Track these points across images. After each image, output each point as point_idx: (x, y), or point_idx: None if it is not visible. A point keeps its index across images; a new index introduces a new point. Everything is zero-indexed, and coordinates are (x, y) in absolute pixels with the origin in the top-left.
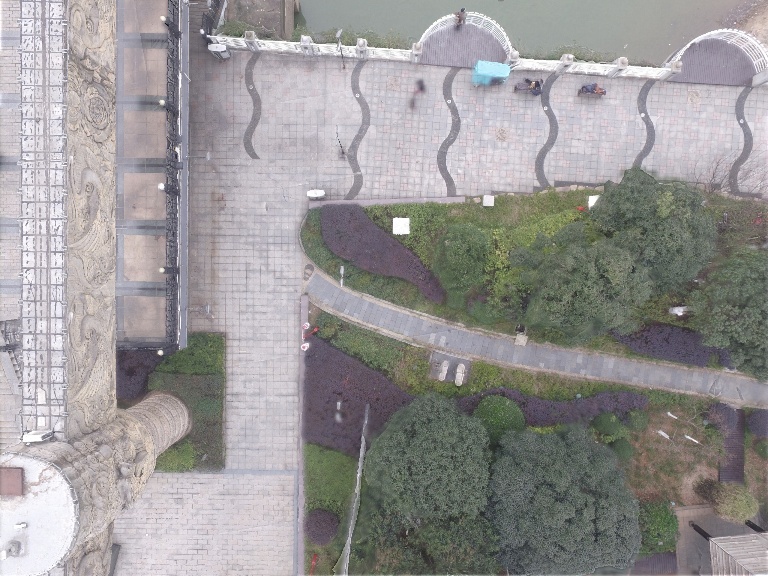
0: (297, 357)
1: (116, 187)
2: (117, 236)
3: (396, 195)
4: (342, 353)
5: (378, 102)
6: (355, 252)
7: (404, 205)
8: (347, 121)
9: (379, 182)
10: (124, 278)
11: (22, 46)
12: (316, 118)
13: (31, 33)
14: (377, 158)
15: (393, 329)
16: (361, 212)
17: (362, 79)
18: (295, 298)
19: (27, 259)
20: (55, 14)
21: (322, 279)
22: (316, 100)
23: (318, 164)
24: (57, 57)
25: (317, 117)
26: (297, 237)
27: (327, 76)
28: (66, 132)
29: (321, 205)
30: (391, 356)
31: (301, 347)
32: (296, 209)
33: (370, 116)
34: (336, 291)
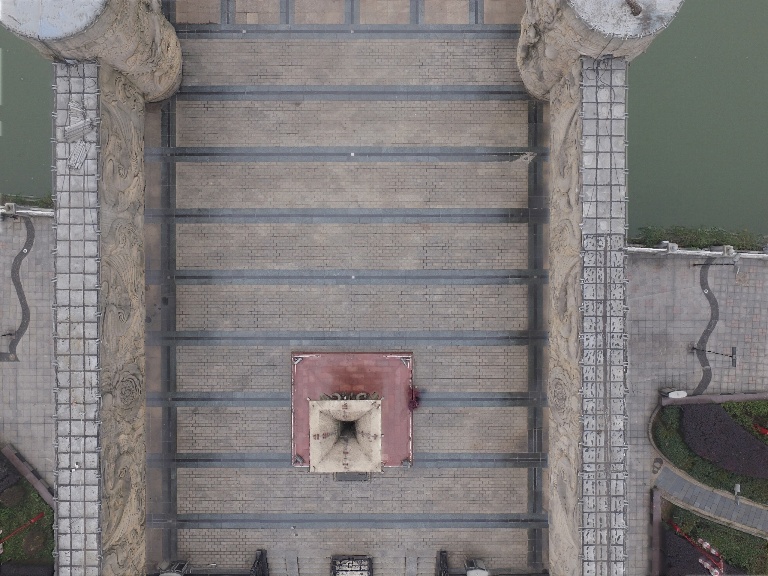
0: (646, 550)
1: (535, 421)
2: (535, 469)
3: (745, 388)
4: (706, 553)
5: (726, 297)
6: (721, 454)
7: (764, 404)
8: (696, 316)
9: (728, 376)
10: (542, 511)
11: (584, 360)
12: (665, 314)
13: (593, 347)
14: (726, 352)
15: (746, 523)
16: (725, 414)
17: (710, 275)
18: (644, 491)
19: (588, 569)
20: (616, 328)
21: (671, 472)
22: (665, 296)
23: (667, 359)
24: (618, 370)
25: (666, 313)
26: (646, 431)
27: (676, 273)
28: (626, 443)
29: (675, 402)
30: (752, 554)
31: (713, 573)
32: (645, 403)
33: (719, 311)
34: (686, 484)
